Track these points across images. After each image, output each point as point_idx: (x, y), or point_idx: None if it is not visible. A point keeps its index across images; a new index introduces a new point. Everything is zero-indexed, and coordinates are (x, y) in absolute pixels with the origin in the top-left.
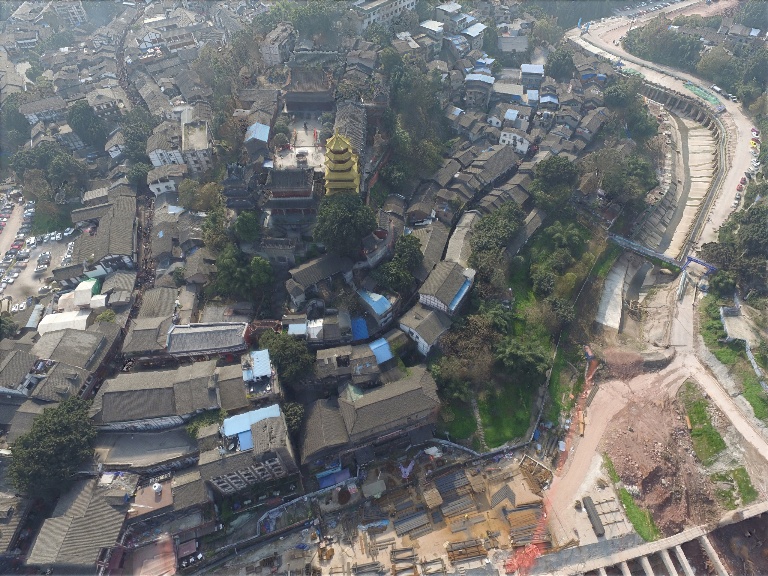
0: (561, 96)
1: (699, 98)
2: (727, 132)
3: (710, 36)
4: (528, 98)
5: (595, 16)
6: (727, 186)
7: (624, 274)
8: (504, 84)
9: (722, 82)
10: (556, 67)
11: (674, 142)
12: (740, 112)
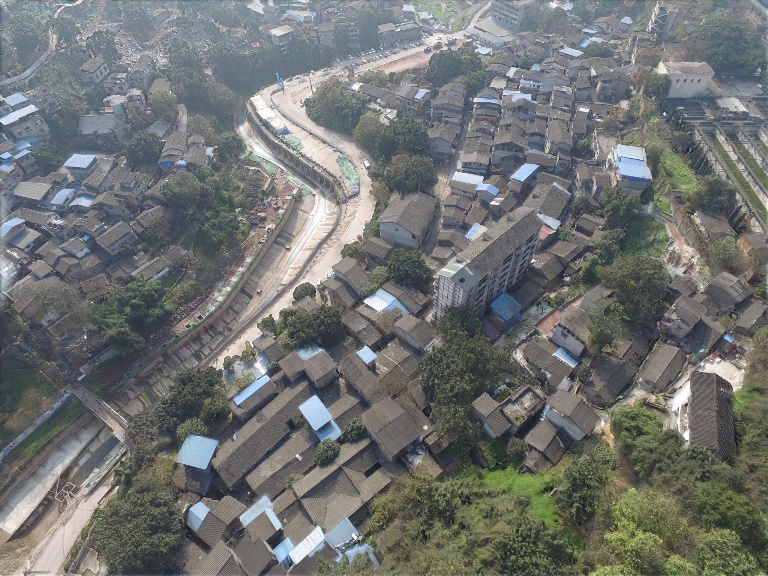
0: (97, 197)
1: (341, 177)
2: (341, 224)
3: (387, 97)
4: (51, 201)
5: (316, 67)
6: (277, 307)
7: (88, 440)
8: (31, 183)
9: (373, 156)
10: (132, 153)
11: (292, 235)
12: (373, 196)
